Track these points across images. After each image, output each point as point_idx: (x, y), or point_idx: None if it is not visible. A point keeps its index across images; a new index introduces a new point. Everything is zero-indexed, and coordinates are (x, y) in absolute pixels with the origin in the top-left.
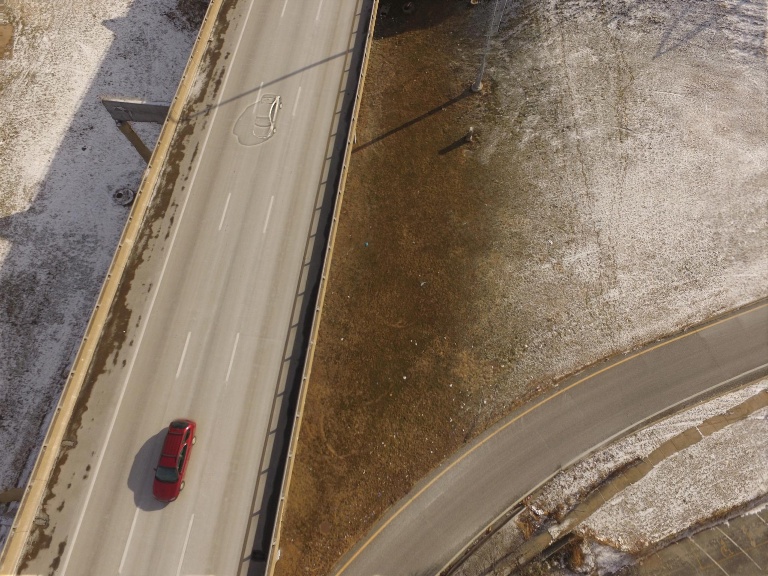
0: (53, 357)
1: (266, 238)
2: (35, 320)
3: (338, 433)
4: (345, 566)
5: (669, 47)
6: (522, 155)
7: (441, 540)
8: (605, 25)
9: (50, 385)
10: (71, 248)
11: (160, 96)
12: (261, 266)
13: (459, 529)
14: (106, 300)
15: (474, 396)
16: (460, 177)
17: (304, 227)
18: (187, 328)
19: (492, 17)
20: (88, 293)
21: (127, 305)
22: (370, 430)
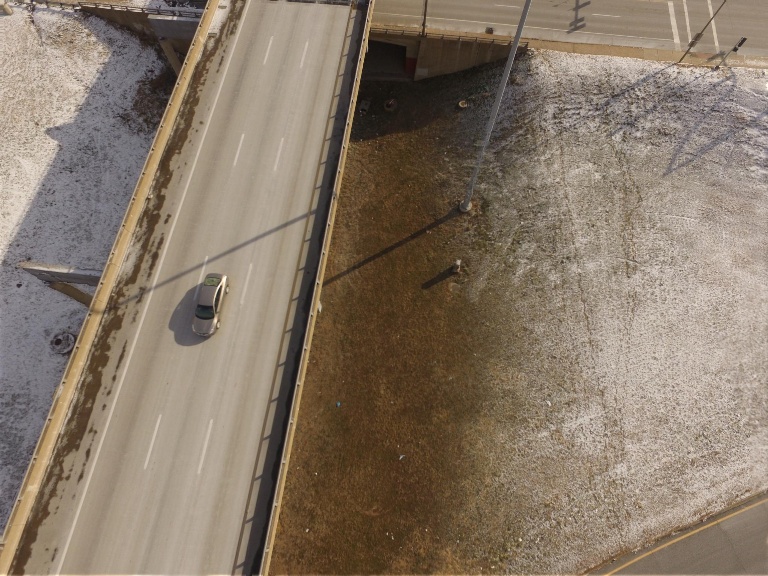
0: None
1: (201, 482)
2: None
3: None
4: None
5: (681, 162)
6: (516, 292)
7: None
8: (609, 137)
9: None
10: None
11: (110, 215)
12: (192, 524)
13: None
14: None
15: None
16: (446, 318)
17: (248, 465)
18: None
19: (483, 124)
20: (16, 469)
21: None
22: None
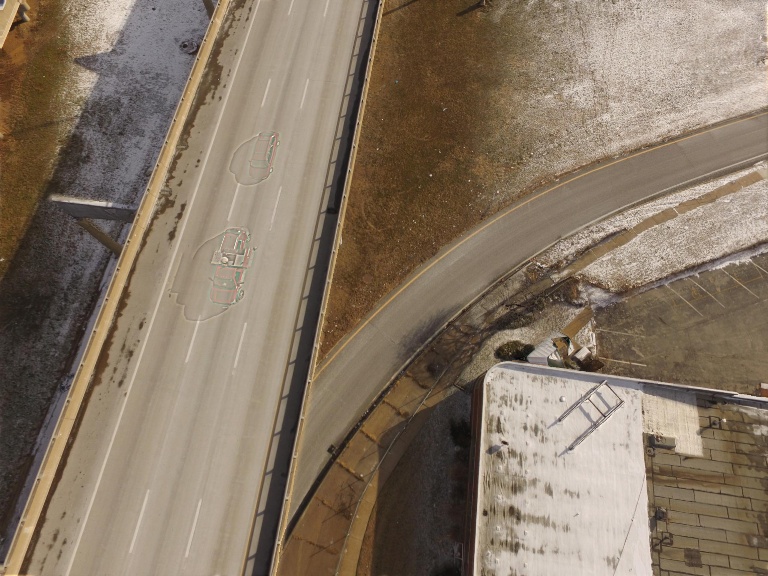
0: (137, 160)
1: (326, 20)
2: (121, 132)
3: (376, 213)
4: (384, 305)
5: None
6: (528, 15)
7: (463, 287)
8: None
9: (136, 180)
10: (147, 82)
11: None
12: (323, 37)
13: (477, 280)
14: (203, 57)
15: (489, 188)
16: (475, 32)
17: (356, 13)
18: (268, 76)
19: None
20: (163, 116)
21: (219, 63)
22: (403, 212)
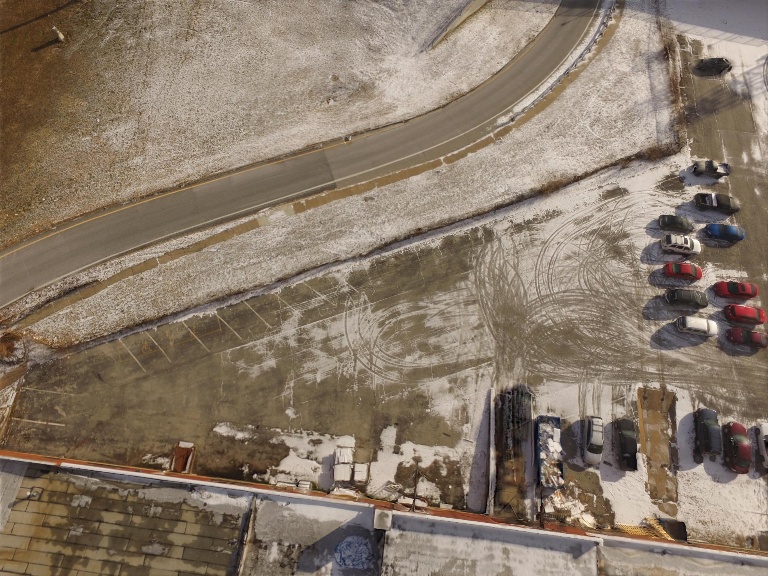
0: None
1: None
2: None
3: None
4: None
5: None
6: (100, 51)
7: None
8: None
9: None
10: None
11: None
12: None
13: None
14: None
15: None
16: (41, 69)
17: None
18: None
19: None
20: None
21: None
22: None
